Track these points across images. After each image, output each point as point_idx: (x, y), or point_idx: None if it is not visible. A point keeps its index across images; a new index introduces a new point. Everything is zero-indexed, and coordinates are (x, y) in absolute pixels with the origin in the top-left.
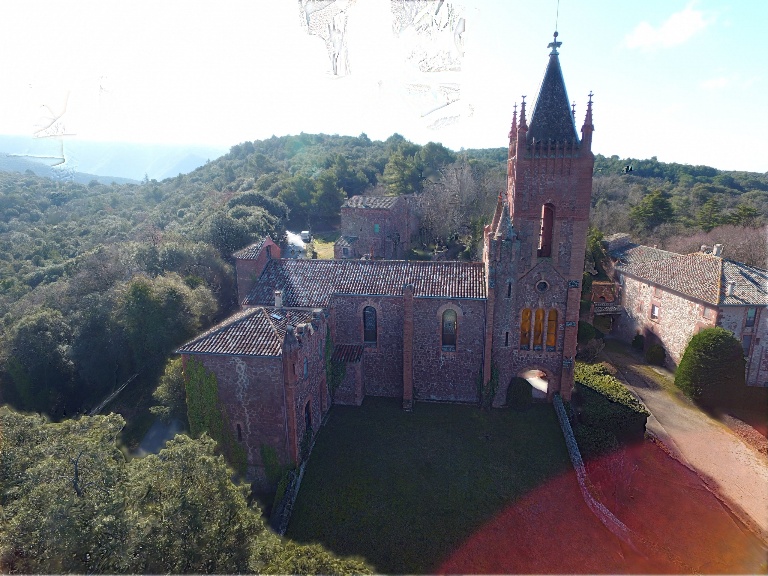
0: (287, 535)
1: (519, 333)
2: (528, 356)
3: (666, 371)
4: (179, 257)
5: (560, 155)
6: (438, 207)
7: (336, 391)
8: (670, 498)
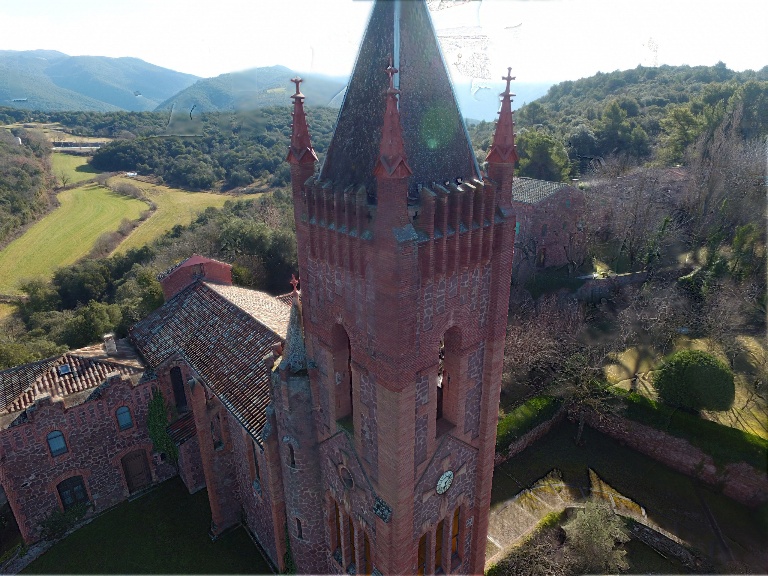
0: None
1: (329, 528)
2: (342, 573)
3: None
4: (248, 241)
5: (343, 226)
6: (599, 211)
7: (178, 463)
8: None
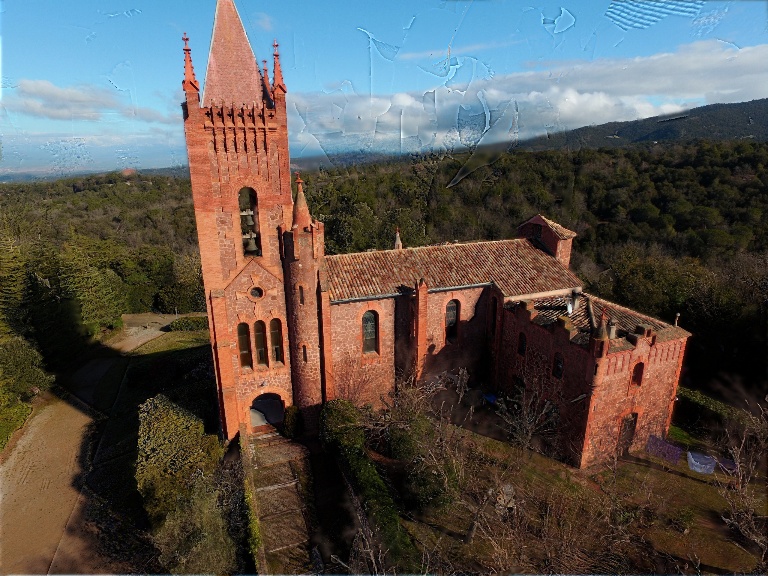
0: None
1: None
2: None
3: None
4: None
5: None
6: None
7: None
8: None
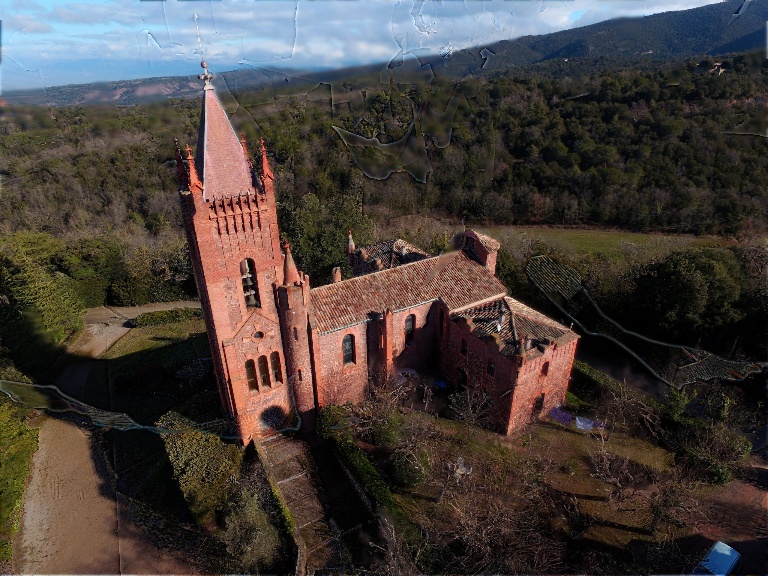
0: None
1: None
2: None
3: None
4: (659, 268)
5: None
6: None
7: None
8: (156, 438)
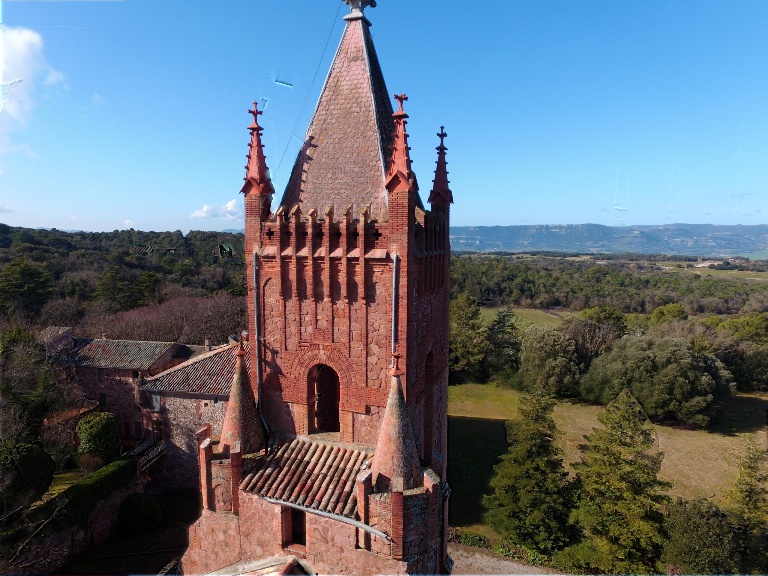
0: None
1: None
2: None
3: None
4: None
5: None
6: None
7: None
8: None
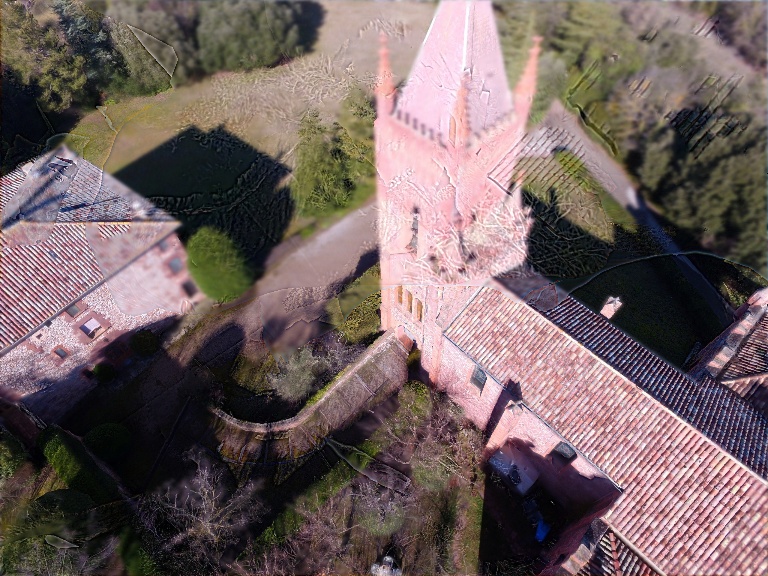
0: (694, 342)
1: None
2: None
3: (173, 330)
4: None
5: None
6: None
7: None
8: None
